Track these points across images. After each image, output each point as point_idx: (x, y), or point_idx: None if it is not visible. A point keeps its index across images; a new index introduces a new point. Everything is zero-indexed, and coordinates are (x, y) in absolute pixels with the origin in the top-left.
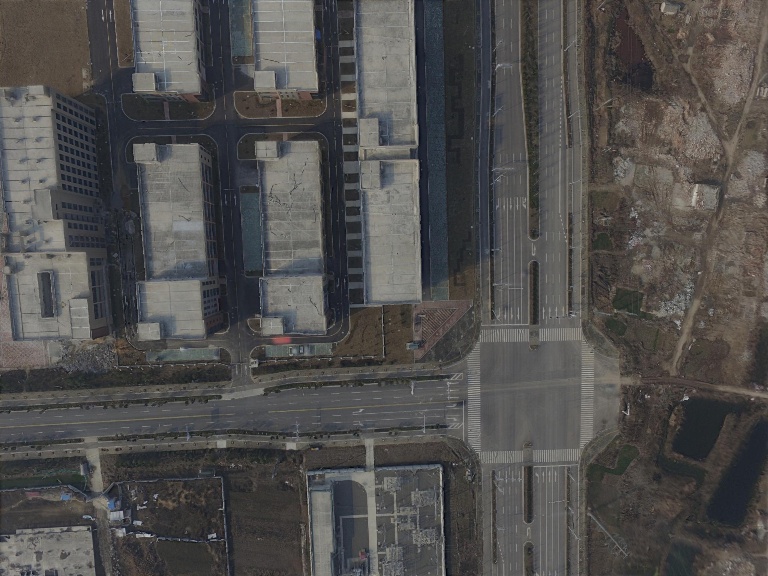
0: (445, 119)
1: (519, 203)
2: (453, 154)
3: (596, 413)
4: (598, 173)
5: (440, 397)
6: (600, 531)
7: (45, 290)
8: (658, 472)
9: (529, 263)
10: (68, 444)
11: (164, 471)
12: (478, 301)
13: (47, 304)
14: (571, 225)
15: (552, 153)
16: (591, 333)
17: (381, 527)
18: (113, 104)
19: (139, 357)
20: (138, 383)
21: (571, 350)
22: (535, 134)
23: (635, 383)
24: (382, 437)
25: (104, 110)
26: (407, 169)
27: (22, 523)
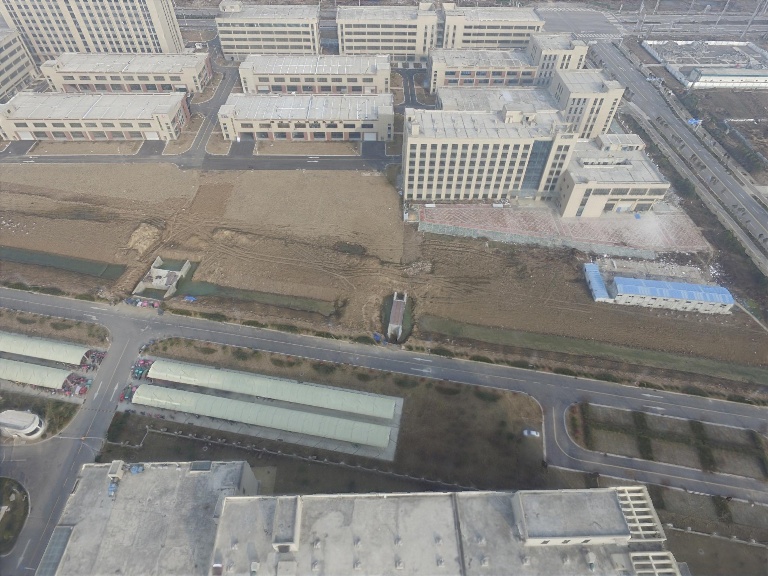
0: None
1: None
2: None
3: None
4: None
5: None
6: None
7: None
8: None
9: None
10: (766, 205)
11: None
12: None
13: None
14: None
15: None
16: None
17: None
18: (395, 160)
19: None
20: None
21: None
22: None
23: None
24: None
25: None
26: None
27: None
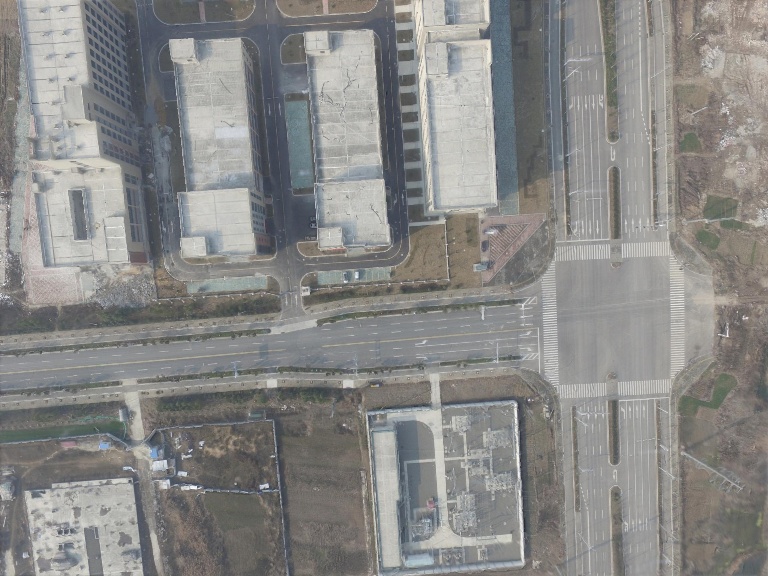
0: (510, 9)
1: (595, 101)
2: (520, 48)
3: (688, 338)
4: (683, 65)
5: (512, 324)
6: (701, 468)
7: (77, 211)
8: (759, 404)
9: (608, 169)
10: (105, 388)
11: (210, 415)
12: (552, 214)
13: (79, 227)
14: (654, 124)
15: (631, 43)
16: (680, 247)
17: (450, 472)
18: (144, 7)
19: (179, 288)
20: (179, 317)
21: (658, 267)
22: (612, 22)
23: (731, 303)
24: (449, 371)
25: (134, 14)
26: (476, 53)
27: (58, 476)
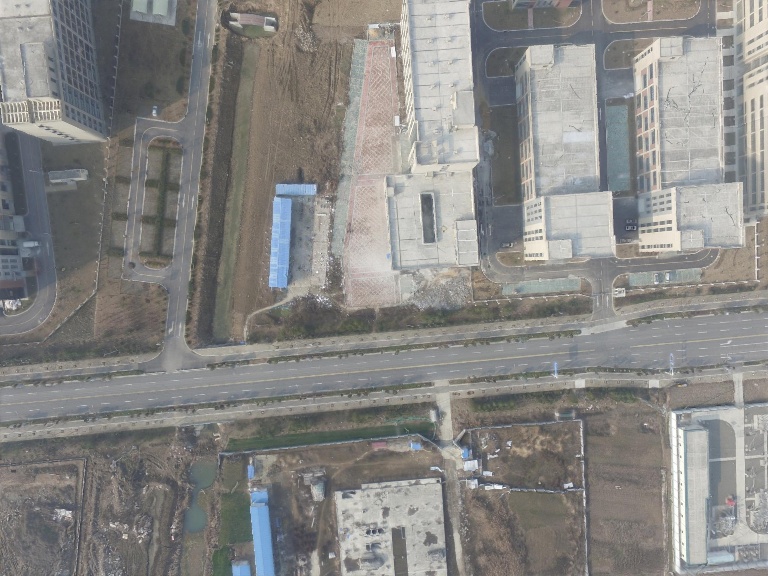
0: None
1: None
2: None
3: None
4: None
5: None
6: None
7: None
8: None
9: None
10: (418, 389)
11: (518, 415)
12: None
13: None
14: None
15: None
16: None
17: (750, 470)
18: (474, 14)
19: (495, 290)
20: (495, 319)
21: None
22: None
23: None
24: (752, 371)
25: None
26: None
27: (367, 477)
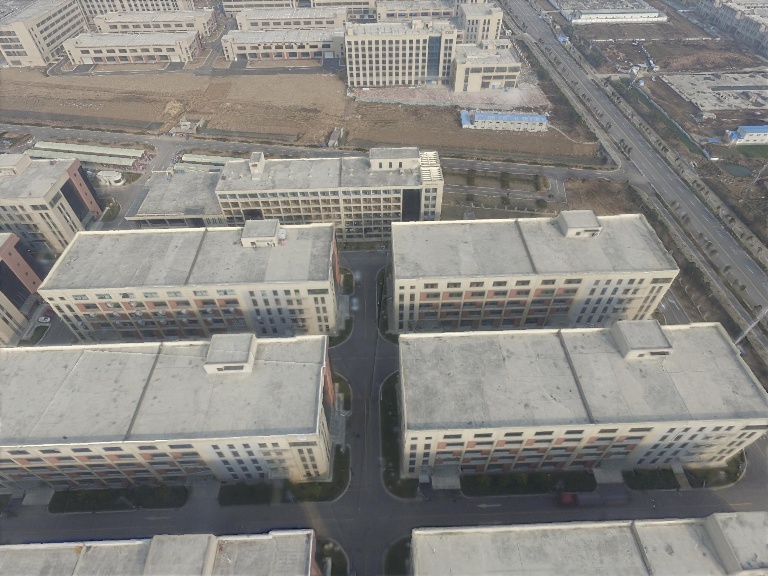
0: None
1: None
2: None
3: None
4: None
5: None
6: None
7: None
8: None
9: None
10: None
11: None
12: None
13: None
14: None
15: None
16: None
17: None
18: None
19: None
20: None
21: None
22: None
23: None
24: None
25: None
26: None
27: None
